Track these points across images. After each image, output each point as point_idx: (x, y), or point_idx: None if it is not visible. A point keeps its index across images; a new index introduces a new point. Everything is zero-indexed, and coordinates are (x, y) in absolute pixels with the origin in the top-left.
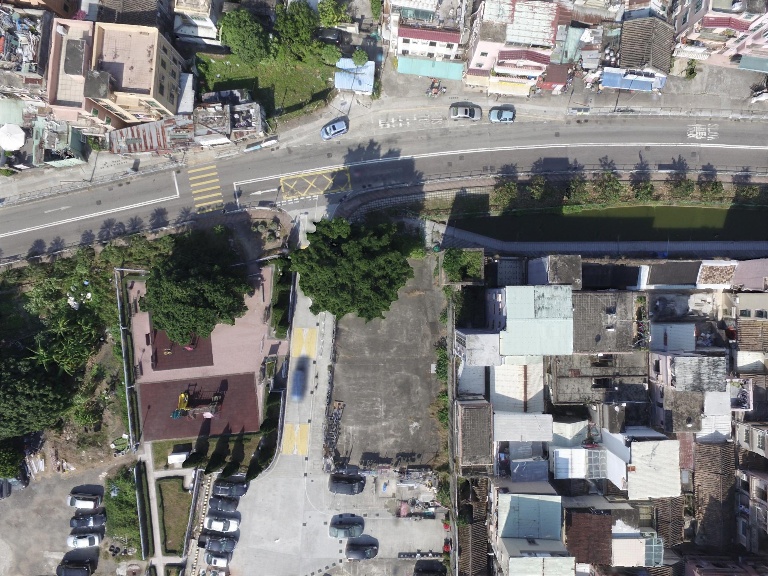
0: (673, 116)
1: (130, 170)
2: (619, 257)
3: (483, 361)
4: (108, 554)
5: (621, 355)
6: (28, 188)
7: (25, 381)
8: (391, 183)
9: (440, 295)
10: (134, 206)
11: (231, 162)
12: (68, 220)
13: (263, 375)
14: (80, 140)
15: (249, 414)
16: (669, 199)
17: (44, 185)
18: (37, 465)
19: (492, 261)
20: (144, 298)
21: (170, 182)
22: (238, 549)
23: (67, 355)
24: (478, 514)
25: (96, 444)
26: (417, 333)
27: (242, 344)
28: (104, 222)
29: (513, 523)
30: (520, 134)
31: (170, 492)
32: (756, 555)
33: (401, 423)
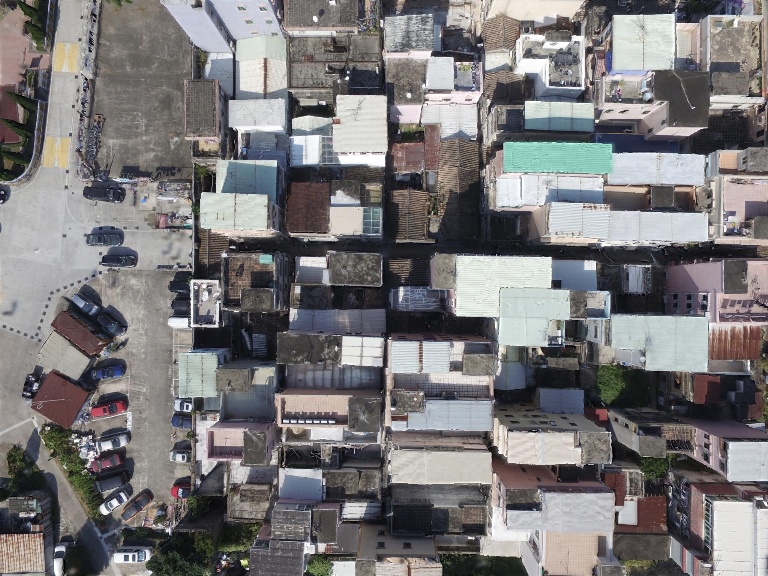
0: None
1: None
2: None
3: None
4: None
5: (355, 42)
6: None
7: None
8: None
9: None
10: None
11: None
12: None
13: (24, 87)
14: None
15: None
16: None
17: None
18: None
19: None
20: None
21: None
22: None
23: None
24: None
25: None
26: (178, 49)
27: (3, 56)
28: None
29: (230, 188)
30: None
31: None
32: None
33: (161, 138)
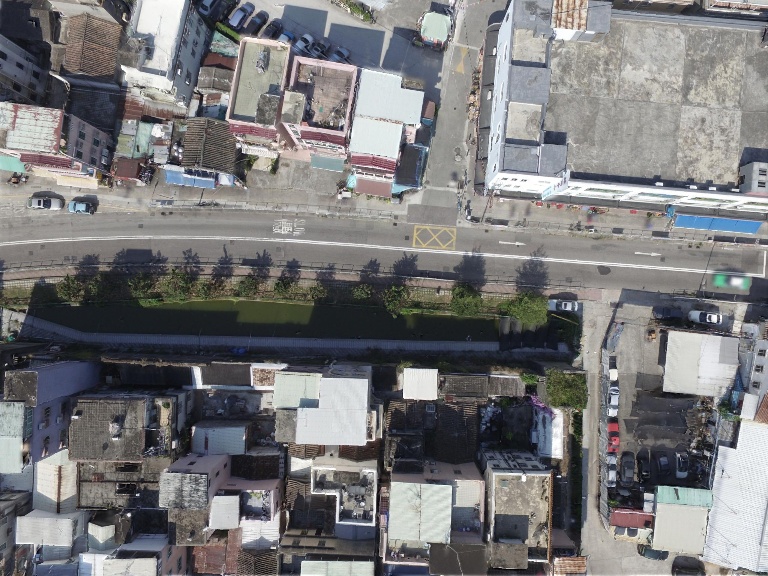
0: (258, 211)
1: None
2: (156, 360)
3: None
4: None
5: (147, 460)
6: None
7: None
8: None
9: None
10: None
11: None
12: None
13: None
14: None
15: None
16: None
17: None
18: None
19: (24, 361)
20: None
21: None
22: None
23: None
24: None
25: None
26: None
27: None
28: None
29: None
30: (103, 225)
31: None
32: None
33: None
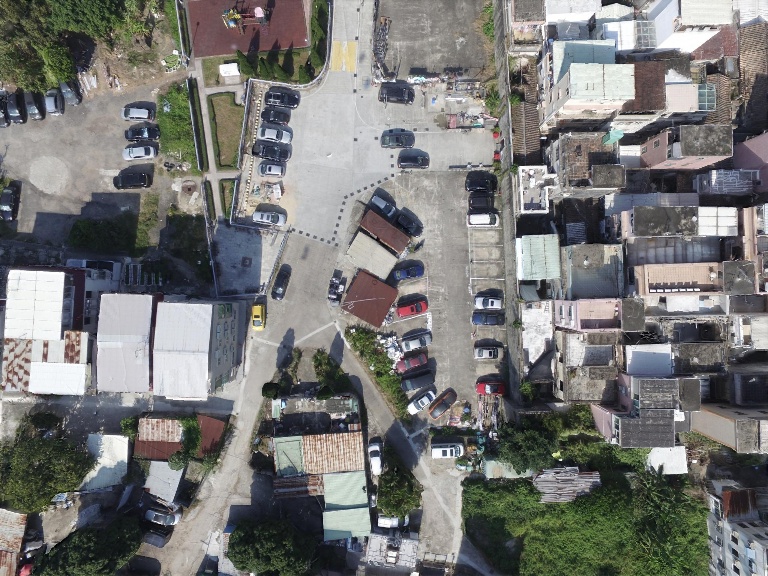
0: None
1: None
2: None
3: None
4: (163, 170)
5: None
6: None
7: None
8: None
9: None
10: None
11: None
12: None
13: None
14: None
15: (297, 30)
16: None
17: None
18: (89, 81)
19: None
20: None
21: None
22: (291, 164)
23: None
24: (529, 98)
25: (147, 61)
26: None
27: None
28: None
29: None
30: None
31: (222, 107)
32: None
33: (447, 38)
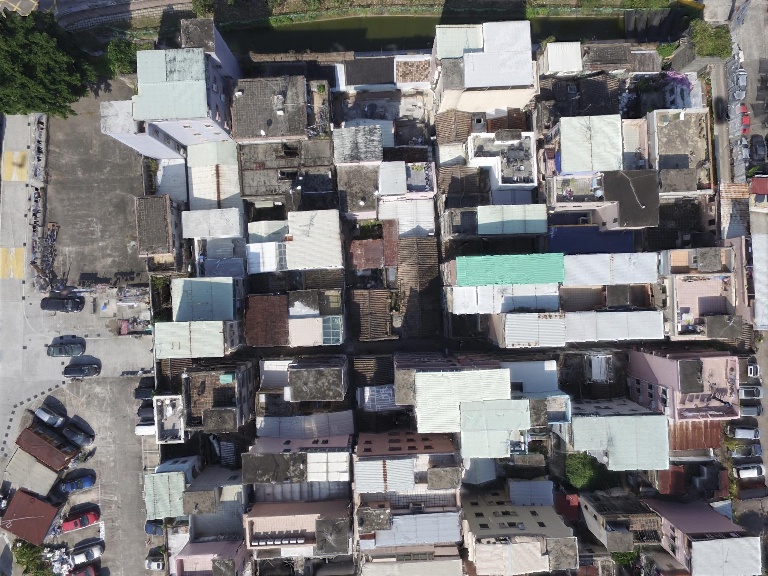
0: None
1: None
2: (304, 51)
3: (118, 128)
4: None
5: (306, 146)
6: None
7: None
8: None
9: None
10: None
11: None
12: None
13: None
14: None
15: None
16: None
17: None
18: None
19: None
20: None
21: None
22: None
23: None
24: None
25: None
26: (130, 152)
27: None
28: None
29: (187, 307)
30: None
31: None
32: (466, 349)
33: (118, 242)
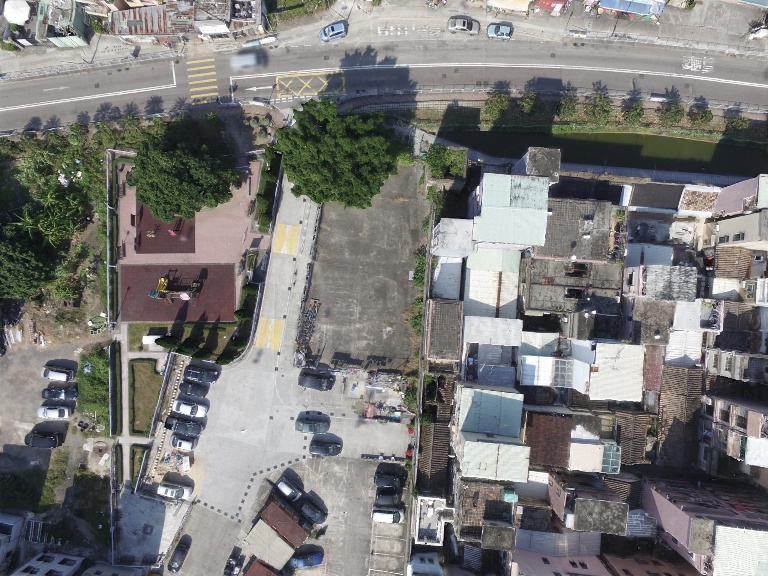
0: (669, 46)
1: (130, 54)
2: (602, 172)
3: (455, 245)
4: (77, 429)
5: (596, 267)
6: (29, 65)
7: (9, 242)
8: (385, 90)
9: (424, 203)
10: (131, 92)
11: (229, 57)
12: (65, 100)
13: (243, 267)
14: (84, 21)
15: (226, 304)
16: (659, 128)
17: (45, 64)
18: (15, 335)
19: (476, 165)
20: (131, 171)
21: (168, 71)
22: (204, 436)
23: (52, 225)
24: (442, 415)
25: (74, 320)
26: (398, 239)
27: (225, 235)
28: (100, 105)
29: (474, 417)
30: (516, 52)
31: (142, 373)
32: (716, 482)
33: (375, 326)
